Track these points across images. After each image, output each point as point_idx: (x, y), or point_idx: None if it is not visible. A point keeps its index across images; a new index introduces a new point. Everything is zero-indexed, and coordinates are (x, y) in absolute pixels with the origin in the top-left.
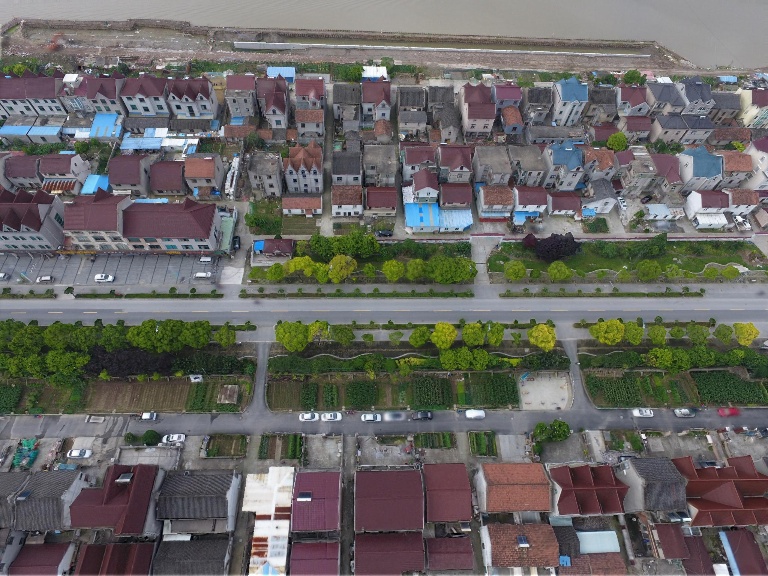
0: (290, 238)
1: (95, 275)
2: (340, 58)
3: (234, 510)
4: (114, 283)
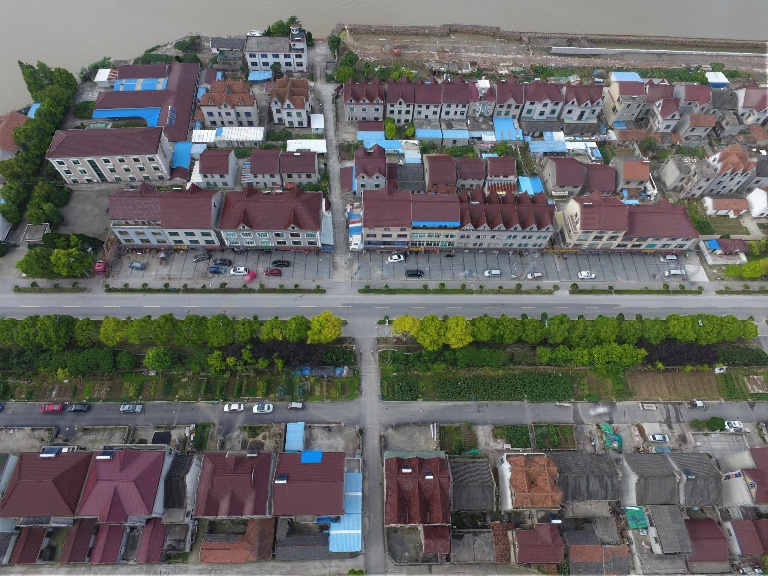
0: None
1: (581, 272)
2: (660, 63)
3: None
4: (596, 280)
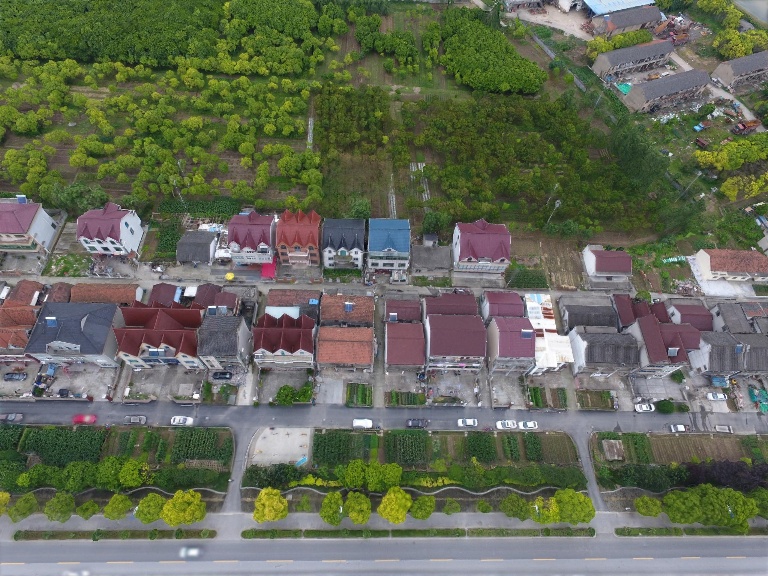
0: None
1: None
2: None
3: (572, 346)
4: None
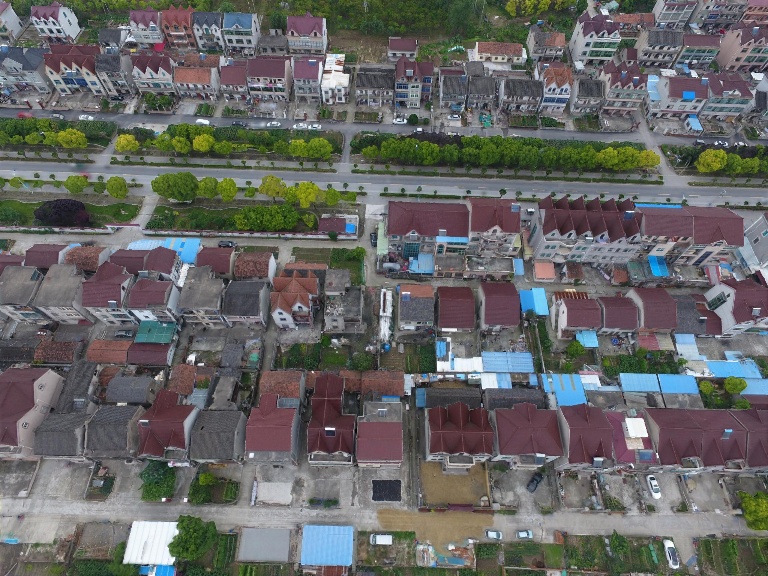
0: (323, 245)
1: None
2: None
3: None
4: None
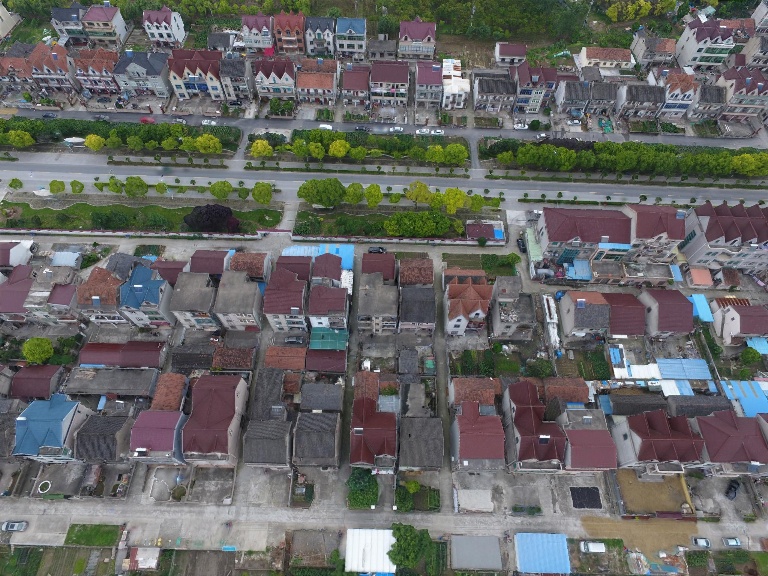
0: (471, 251)
1: None
2: None
3: None
4: None
